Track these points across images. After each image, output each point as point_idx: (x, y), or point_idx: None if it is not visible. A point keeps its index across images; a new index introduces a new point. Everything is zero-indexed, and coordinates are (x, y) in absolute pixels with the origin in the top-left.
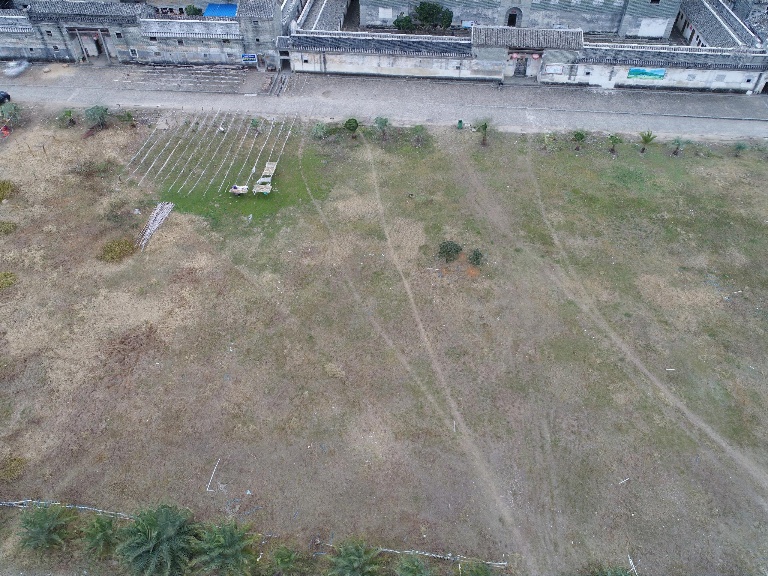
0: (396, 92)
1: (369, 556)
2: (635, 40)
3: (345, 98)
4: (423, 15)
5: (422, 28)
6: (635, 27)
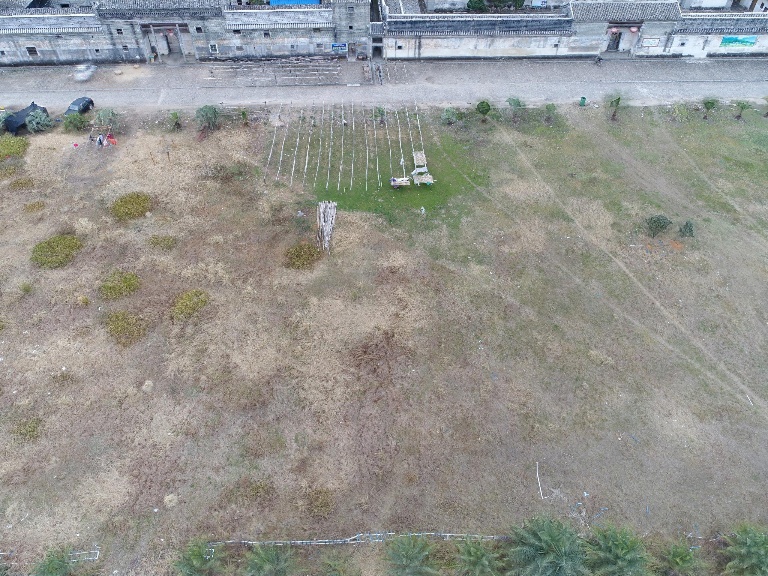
0: (499, 74)
1: None
2: (699, 11)
3: (451, 83)
4: None
5: (489, 10)
6: None
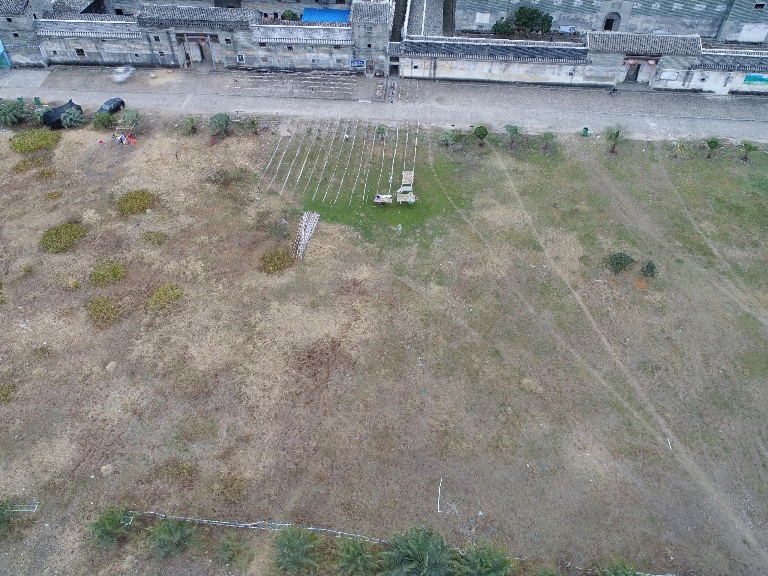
0: (510, 98)
1: None
2: (734, 45)
3: (460, 104)
4: (523, 20)
5: (517, 33)
6: (736, 32)
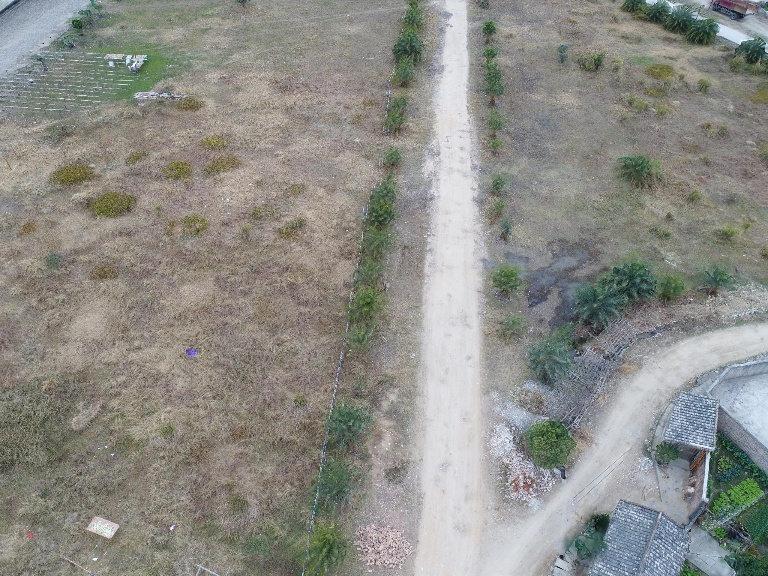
0: (18, 22)
1: None
2: None
3: (10, 39)
4: None
5: None
6: None
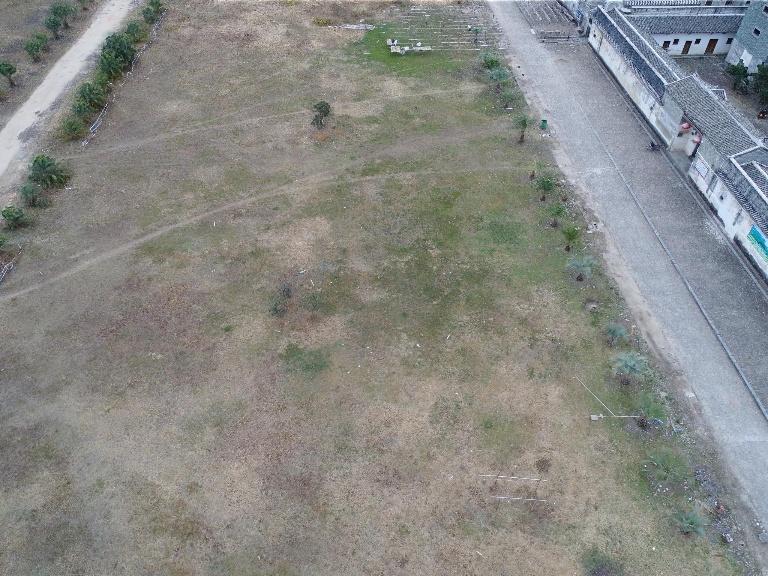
0: (592, 91)
1: (91, 94)
2: None
3: (560, 69)
4: (756, 74)
5: None
6: None
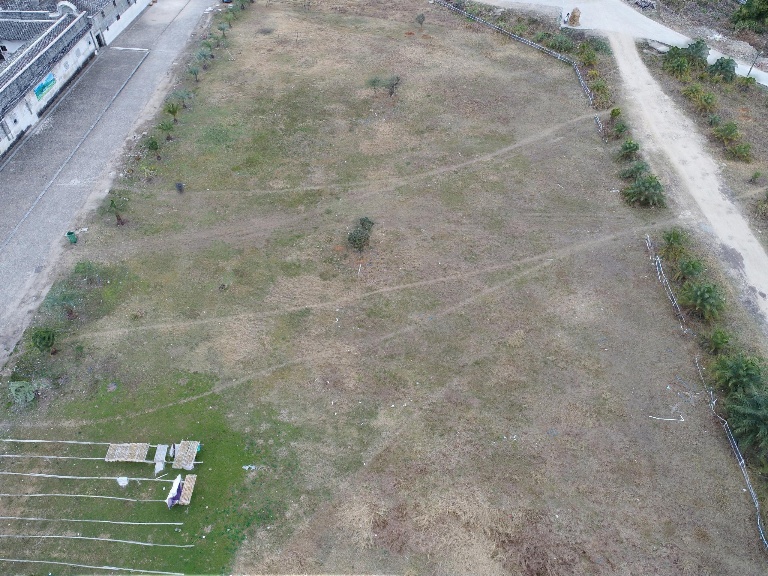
0: None
1: (696, 286)
2: None
3: None
4: None
5: None
6: None
